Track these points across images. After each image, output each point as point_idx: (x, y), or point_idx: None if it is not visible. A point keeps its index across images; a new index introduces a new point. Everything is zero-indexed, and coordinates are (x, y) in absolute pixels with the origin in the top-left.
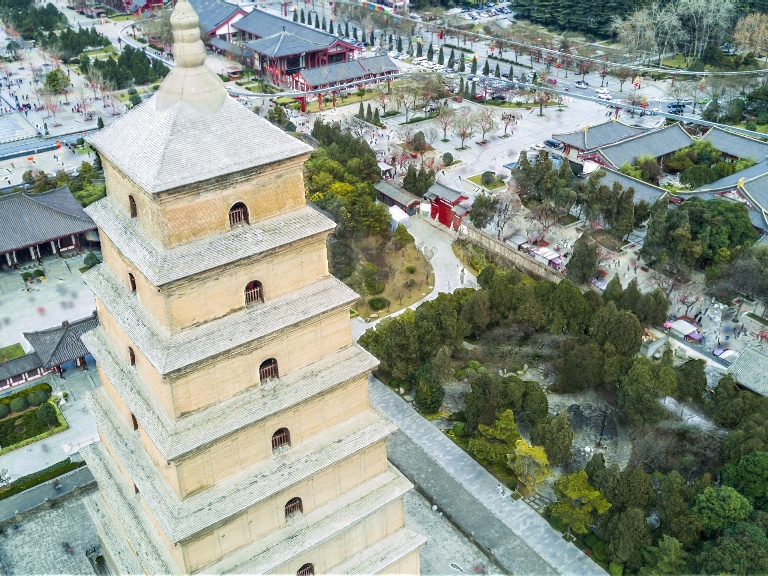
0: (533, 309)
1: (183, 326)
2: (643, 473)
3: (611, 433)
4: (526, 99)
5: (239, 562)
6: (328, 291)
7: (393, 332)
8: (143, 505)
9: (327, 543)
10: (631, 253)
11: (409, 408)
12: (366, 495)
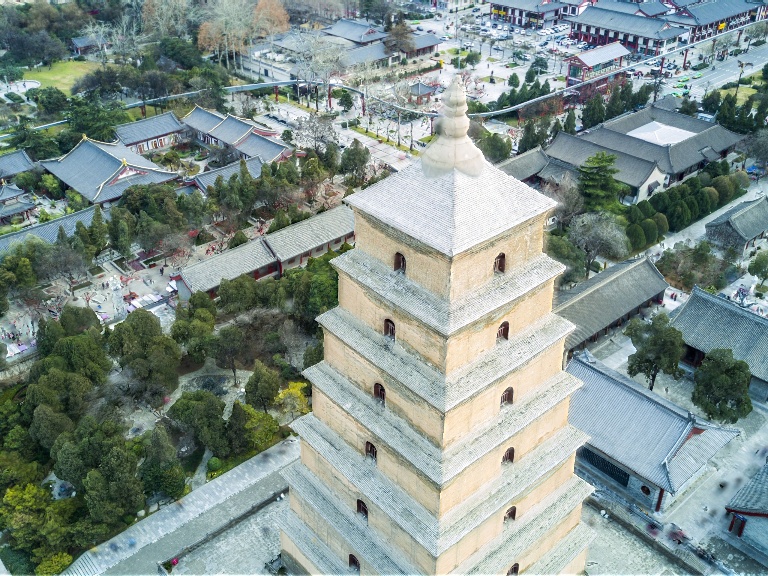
0: (82, 378)
1: None
2: None
3: None
4: None
5: None
6: None
7: (100, 479)
8: None
9: None
10: None
11: (170, 508)
12: None
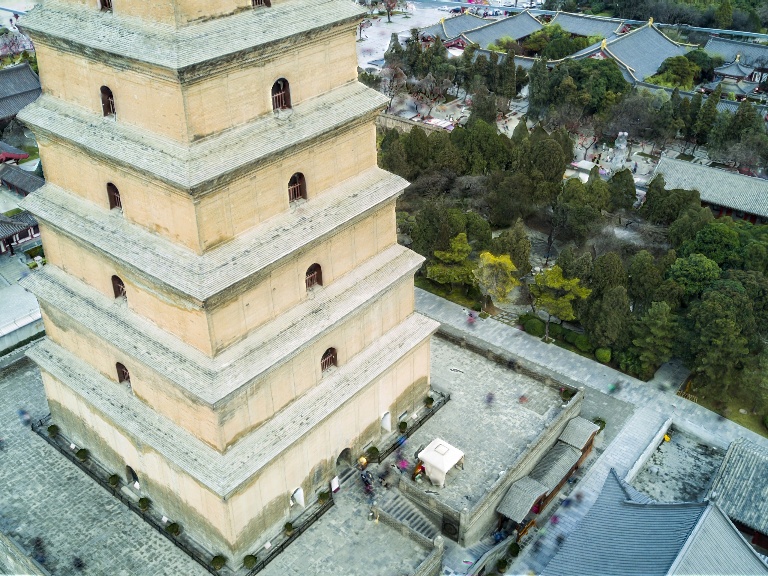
0: (453, 153)
1: (188, 18)
2: (616, 255)
3: (554, 255)
4: (371, 10)
5: (266, 339)
6: (334, 2)
7: None
8: (130, 304)
9: (348, 323)
10: (516, 119)
11: None
12: (381, 267)
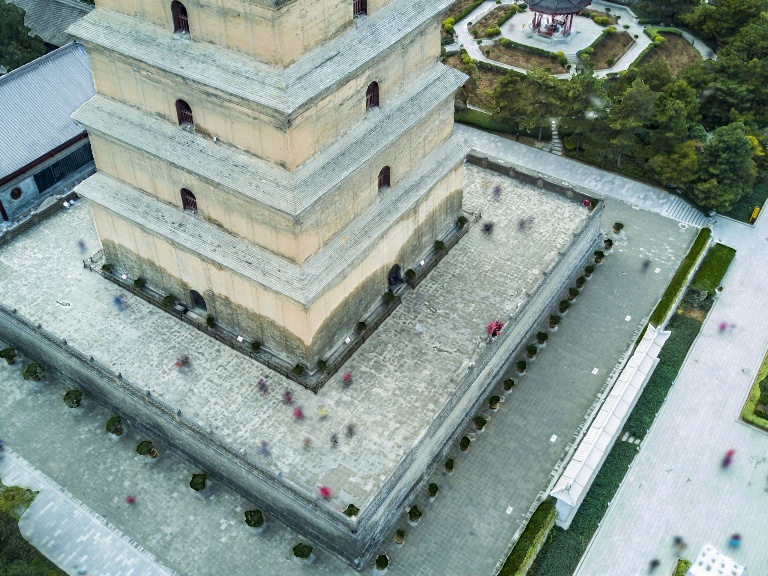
0: None
1: None
2: None
3: None
4: None
5: None
6: None
7: None
8: None
9: None
10: None
11: None
12: None
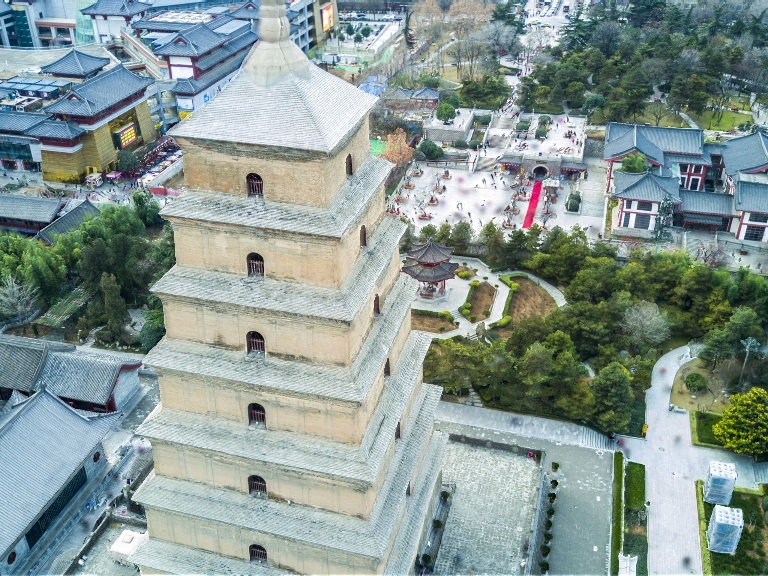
0: None
1: None
2: None
3: None
4: None
5: None
6: None
7: None
8: None
9: None
10: None
11: None
12: None
